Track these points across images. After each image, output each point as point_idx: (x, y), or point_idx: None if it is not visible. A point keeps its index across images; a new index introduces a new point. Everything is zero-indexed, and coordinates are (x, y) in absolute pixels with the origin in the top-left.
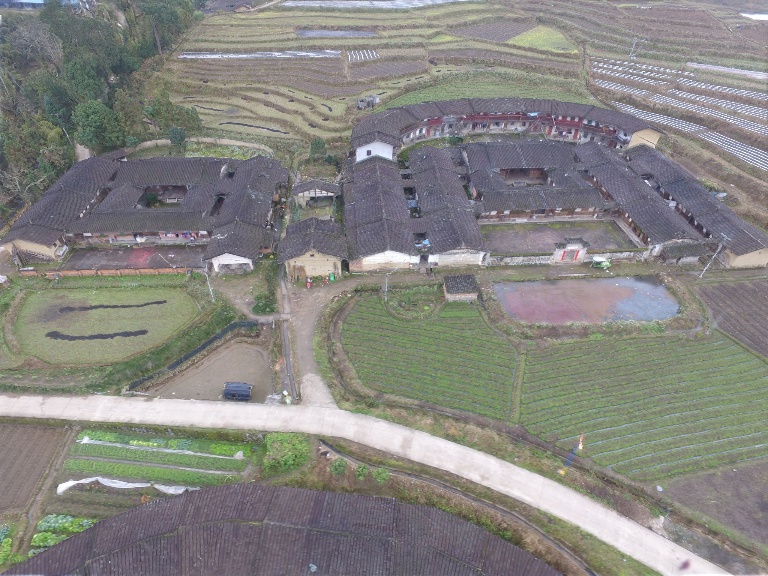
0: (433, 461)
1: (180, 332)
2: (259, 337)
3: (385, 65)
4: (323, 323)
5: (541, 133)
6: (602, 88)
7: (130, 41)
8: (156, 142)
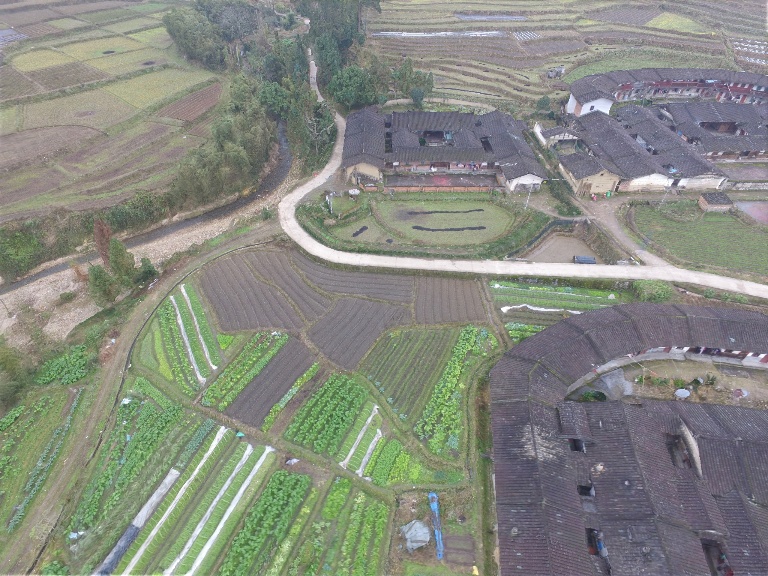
0: (767, 296)
1: (514, 227)
2: (573, 232)
3: (549, 44)
4: (624, 221)
5: (712, 98)
6: (752, 63)
7: (346, 20)
8: (396, 101)
